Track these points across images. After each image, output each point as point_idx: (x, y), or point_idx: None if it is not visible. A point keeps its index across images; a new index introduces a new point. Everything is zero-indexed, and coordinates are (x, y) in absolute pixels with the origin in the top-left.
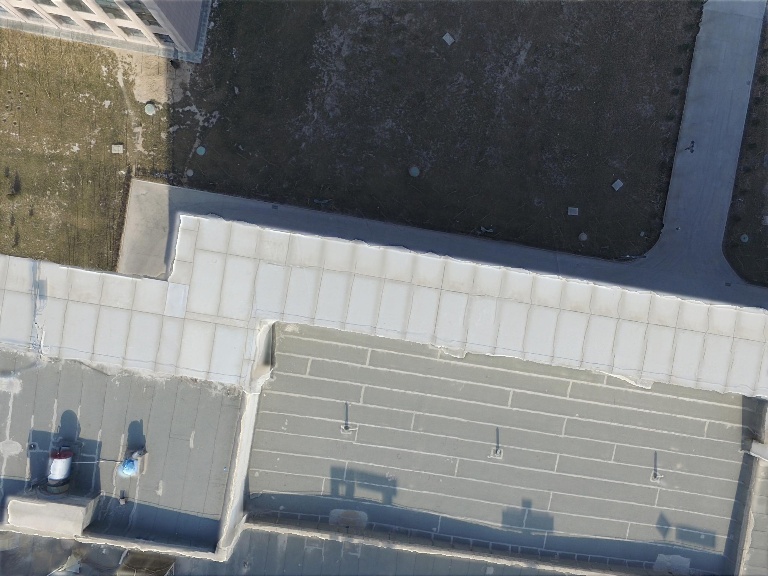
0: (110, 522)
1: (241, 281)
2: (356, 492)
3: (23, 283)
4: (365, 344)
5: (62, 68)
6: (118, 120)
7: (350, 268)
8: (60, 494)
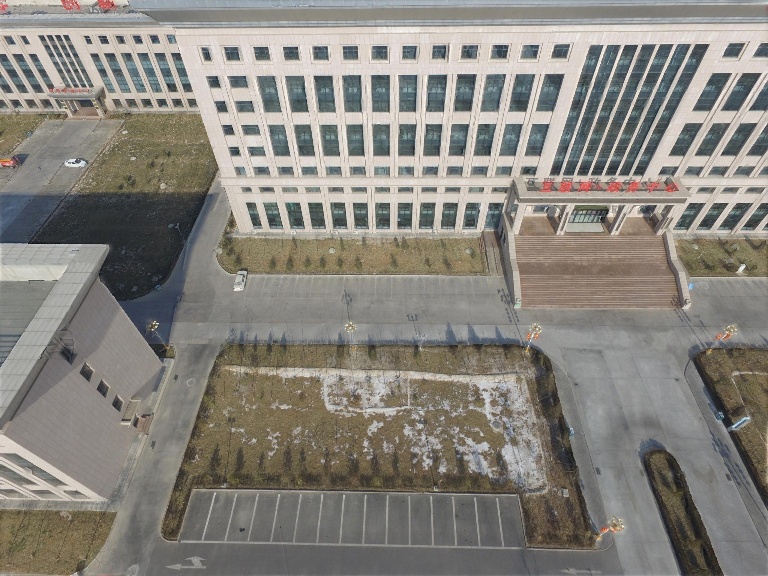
0: None
1: None
2: None
3: None
4: None
5: None
6: None
7: None
8: None
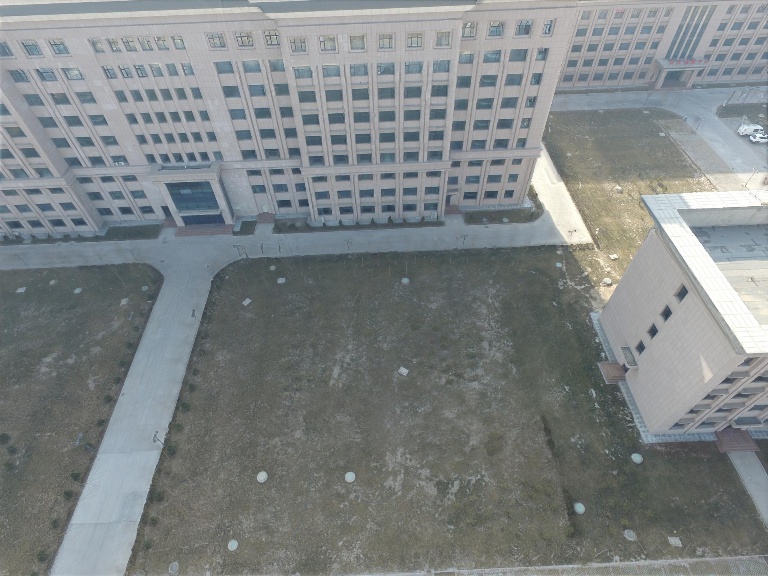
0: None
1: None
2: None
3: None
4: None
5: None
6: None
7: None
8: None
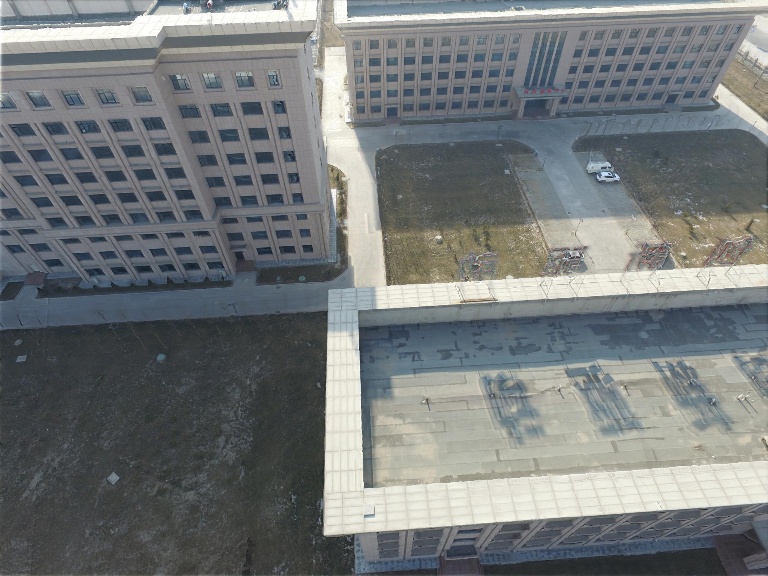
0: (195, 1)
1: None
2: None
3: None
4: None
5: None
6: None
7: (92, 35)
8: None
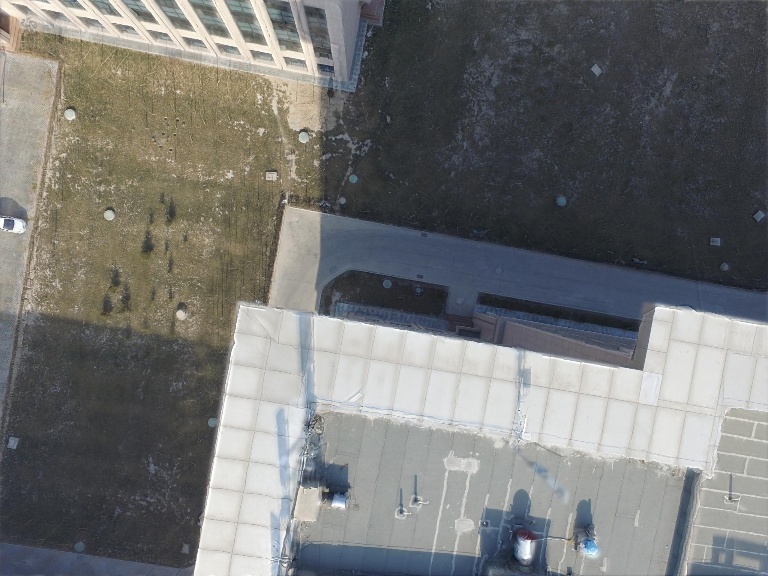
0: None
1: (710, 370)
2: (734, 560)
3: (509, 372)
4: (752, 418)
5: (218, 96)
6: (272, 148)
7: None
8: (531, 574)
